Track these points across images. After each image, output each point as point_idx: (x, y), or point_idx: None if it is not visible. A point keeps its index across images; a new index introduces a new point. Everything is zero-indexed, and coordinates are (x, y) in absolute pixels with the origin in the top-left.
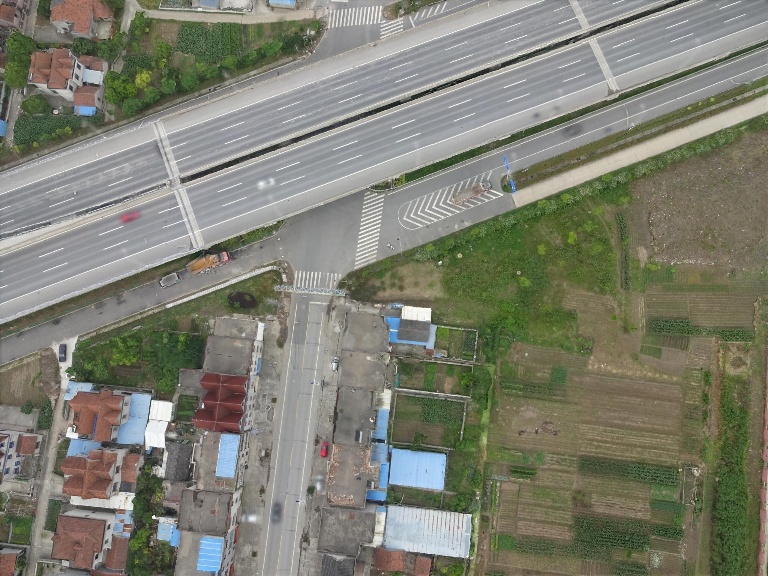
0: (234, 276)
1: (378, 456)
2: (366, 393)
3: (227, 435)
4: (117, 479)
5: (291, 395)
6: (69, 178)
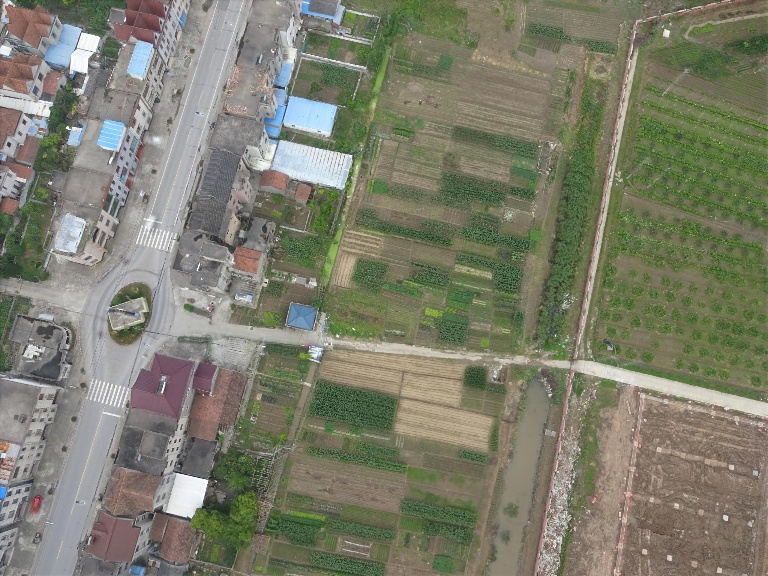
0: None
1: (277, 99)
2: (271, 30)
3: (142, 42)
4: (39, 86)
5: (208, 49)
6: None
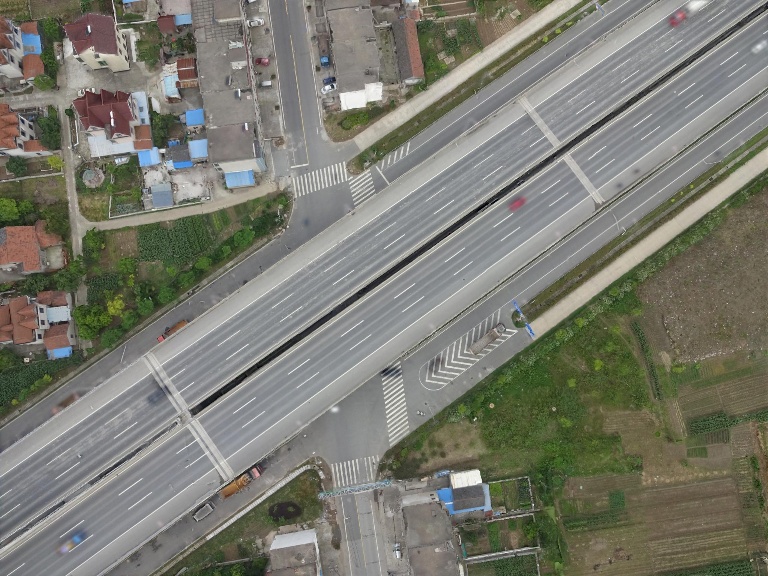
0: (269, 487)
1: None
2: None
3: None
4: None
5: None
6: (68, 441)
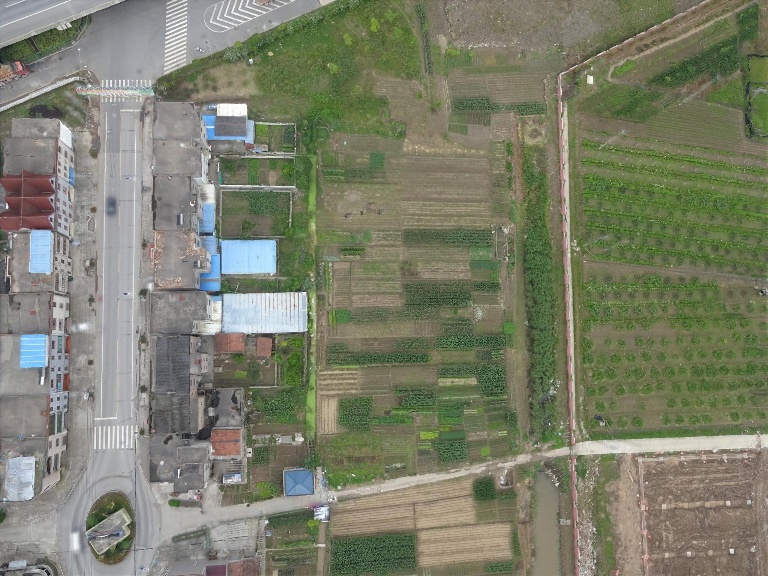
0: (33, 90)
1: (208, 248)
2: (183, 179)
3: (37, 231)
4: None
5: (111, 203)
6: None
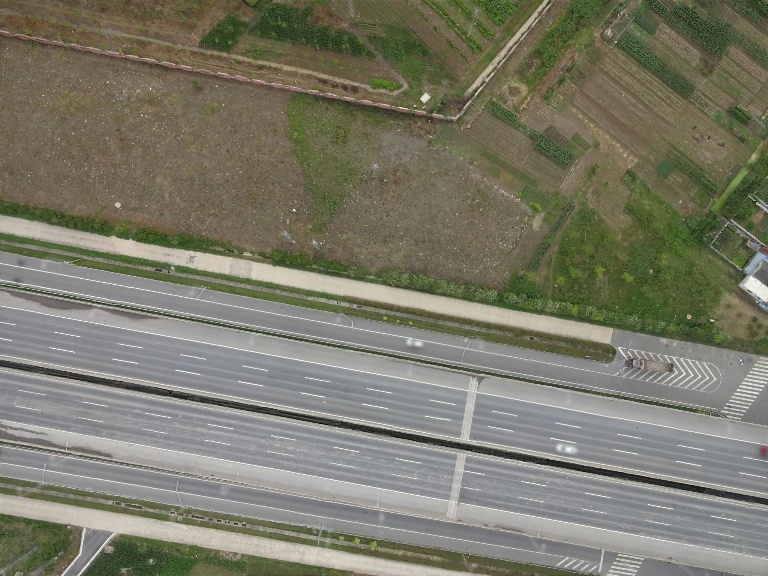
0: None
1: None
2: None
3: None
4: None
5: None
6: None
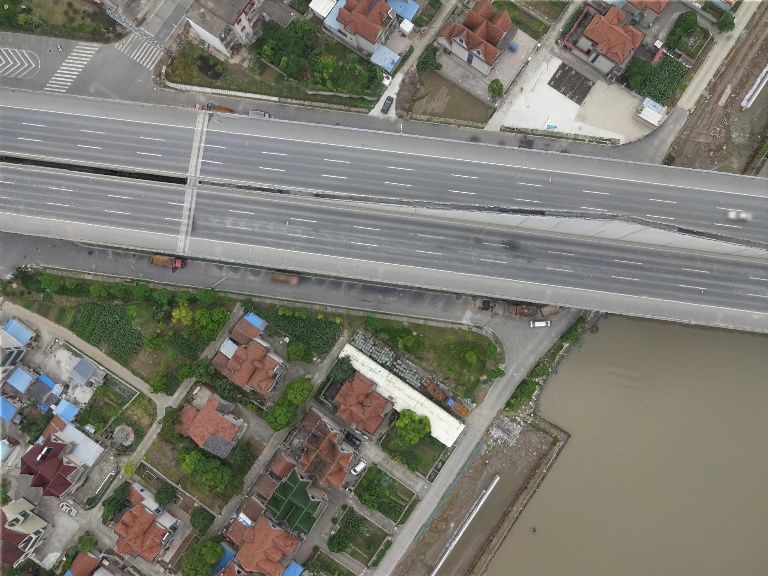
0: (206, 95)
1: None
2: None
3: None
4: None
5: None
6: (286, 241)
